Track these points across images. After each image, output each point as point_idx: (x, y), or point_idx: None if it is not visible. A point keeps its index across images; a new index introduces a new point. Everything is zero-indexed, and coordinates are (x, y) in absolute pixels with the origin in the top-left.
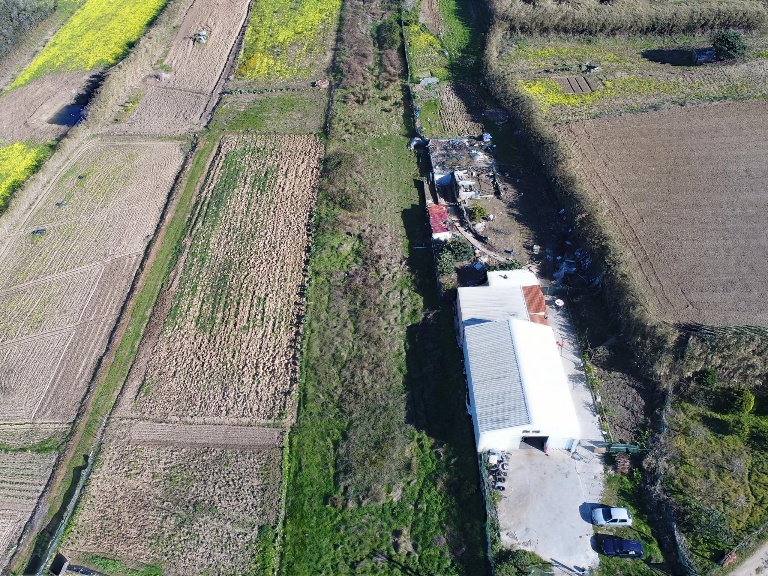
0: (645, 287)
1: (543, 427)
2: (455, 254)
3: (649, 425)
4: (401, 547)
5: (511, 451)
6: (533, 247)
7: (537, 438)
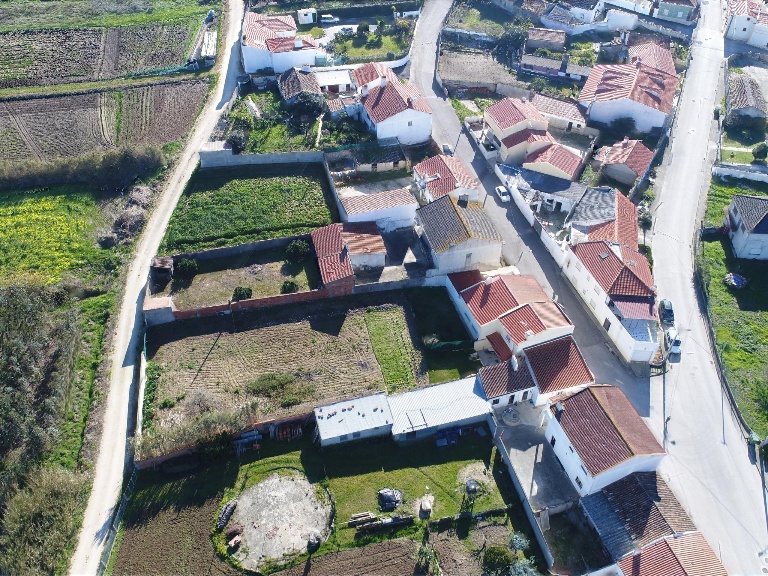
0: None
1: None
2: None
3: None
4: None
5: None
6: None
7: None
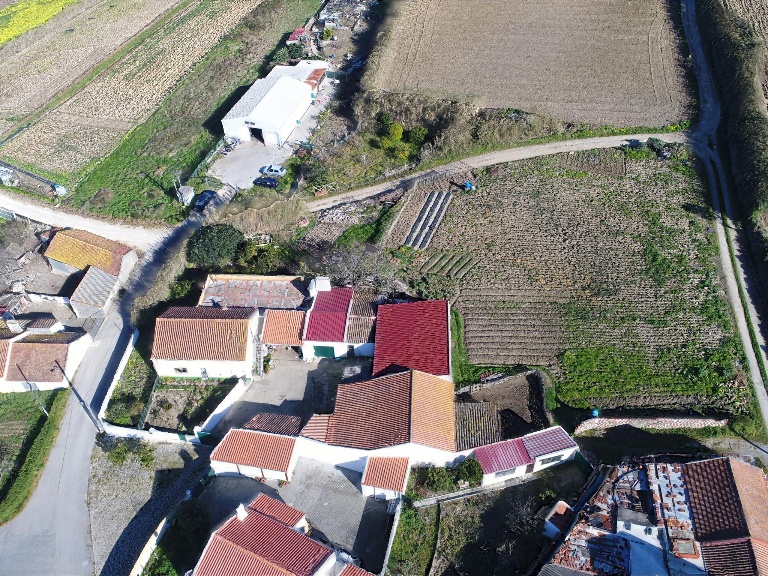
0: (396, 77)
1: (256, 120)
2: (290, 50)
3: (336, 140)
4: (156, 172)
5: (245, 141)
6: (347, 54)
7: (256, 130)
